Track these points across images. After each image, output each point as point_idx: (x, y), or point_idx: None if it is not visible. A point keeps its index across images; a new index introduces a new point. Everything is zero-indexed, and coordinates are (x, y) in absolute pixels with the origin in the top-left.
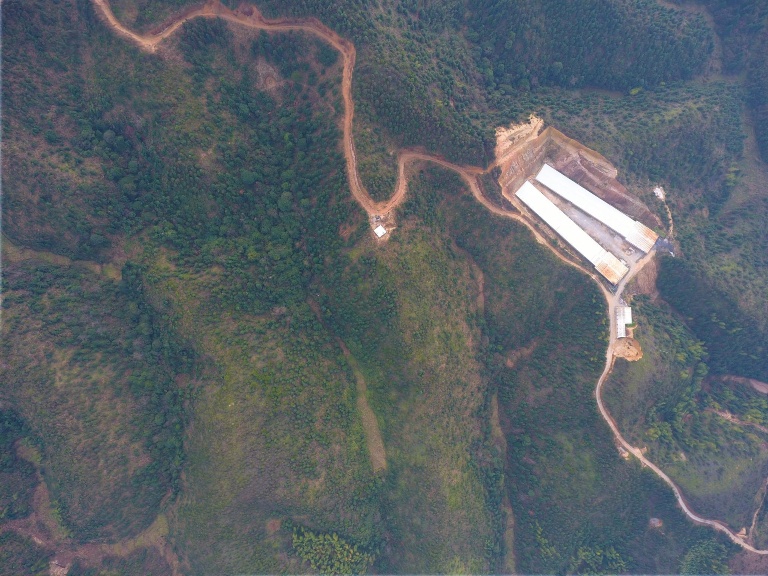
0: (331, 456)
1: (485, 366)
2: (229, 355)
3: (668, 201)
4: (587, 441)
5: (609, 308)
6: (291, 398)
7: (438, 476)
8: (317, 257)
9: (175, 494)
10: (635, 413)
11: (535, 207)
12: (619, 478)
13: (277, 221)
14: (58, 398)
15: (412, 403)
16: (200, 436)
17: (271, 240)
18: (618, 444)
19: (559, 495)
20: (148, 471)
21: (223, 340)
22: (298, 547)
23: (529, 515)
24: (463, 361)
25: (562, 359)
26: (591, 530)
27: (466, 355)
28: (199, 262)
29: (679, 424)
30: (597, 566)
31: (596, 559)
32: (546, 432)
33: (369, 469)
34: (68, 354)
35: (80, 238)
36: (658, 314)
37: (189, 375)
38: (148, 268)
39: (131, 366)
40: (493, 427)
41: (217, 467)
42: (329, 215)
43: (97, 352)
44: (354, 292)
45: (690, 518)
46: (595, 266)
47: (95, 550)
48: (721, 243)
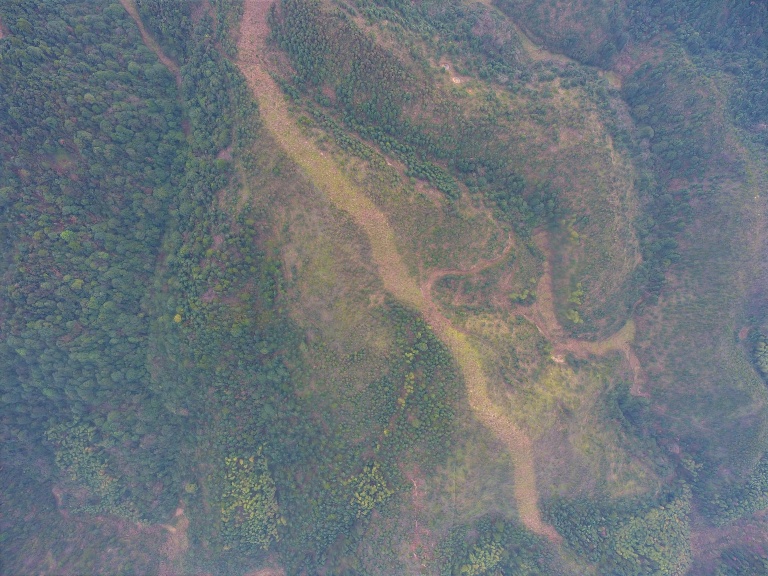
0: None
1: None
2: (746, 153)
3: None
4: None
5: None
6: None
7: None
8: None
9: None
10: None
11: None
12: None
13: None
14: (614, 175)
15: None
16: (713, 230)
17: None
18: None
19: None
20: (644, 268)
21: (740, 139)
22: (761, 356)
23: None
24: None
25: None
26: None
27: None
28: None
29: None
30: None
31: None
32: None
33: None
34: (610, 140)
35: (611, 35)
36: None
37: (686, 179)
38: (678, 65)
39: None
40: None
41: (739, 256)
42: None
43: None
44: None
45: None
46: None
47: (579, 346)
48: None
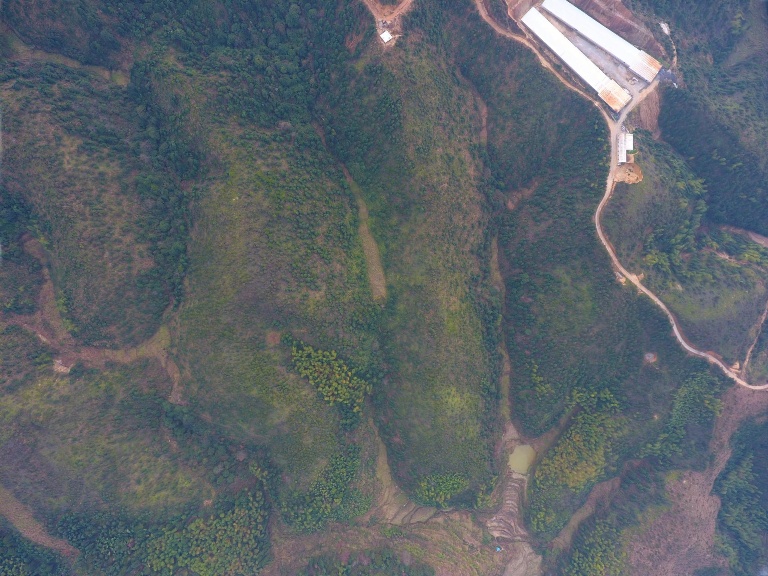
0: (332, 272)
1: (486, 199)
2: (234, 154)
3: (673, 35)
4: (585, 270)
5: (611, 135)
6: (294, 204)
7: (437, 297)
8: (323, 73)
9: (178, 301)
10: (633, 236)
11: (540, 33)
12: (615, 304)
13: (284, 40)
14: (66, 179)
15: (413, 223)
16: (204, 234)
17: (278, 55)
18: (616, 269)
19: (556, 329)
20: (152, 274)
21: (229, 139)
22: (297, 361)
23: (525, 355)
24: (465, 187)
25: (563, 191)
26: (586, 369)
27: (468, 182)
28: (207, 65)
29: (677, 258)
30: (591, 409)
31: (590, 402)
32: (545, 268)
33: (369, 295)
34: (76, 142)
35: (90, 34)
36: (659, 147)
37: (194, 181)
38: (157, 64)
39: (138, 166)
40: (492, 271)
41: (220, 260)
42: (336, 23)
43: (105, 147)
44: (359, 107)
45: (684, 348)
46: (598, 93)
47: (98, 354)
48: (724, 87)
